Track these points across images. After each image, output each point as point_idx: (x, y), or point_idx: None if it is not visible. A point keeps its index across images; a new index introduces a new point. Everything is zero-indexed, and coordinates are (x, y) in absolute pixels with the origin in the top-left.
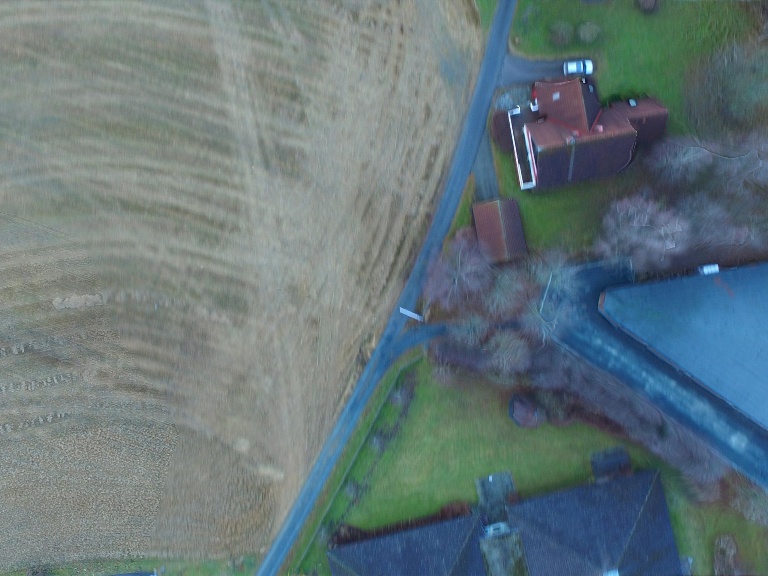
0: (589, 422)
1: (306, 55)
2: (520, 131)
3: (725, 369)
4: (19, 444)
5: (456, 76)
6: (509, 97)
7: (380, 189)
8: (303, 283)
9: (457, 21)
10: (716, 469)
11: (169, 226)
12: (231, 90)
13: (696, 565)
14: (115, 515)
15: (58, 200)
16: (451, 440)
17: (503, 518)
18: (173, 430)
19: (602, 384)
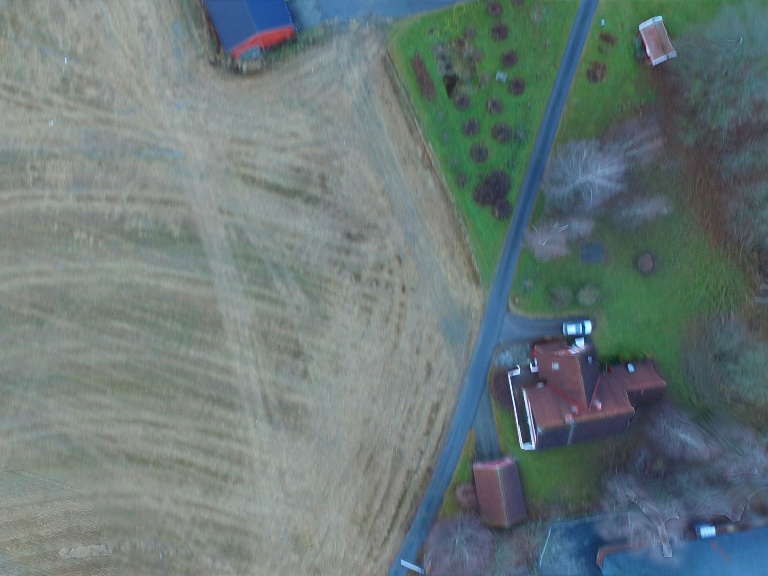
0: None
1: (309, 314)
2: (520, 391)
3: None
4: None
5: (457, 334)
6: (509, 354)
7: (382, 444)
8: (306, 533)
9: (458, 281)
10: None
11: (174, 478)
12: (235, 348)
13: None
14: None
15: (64, 454)
16: None
17: None
18: None
19: None
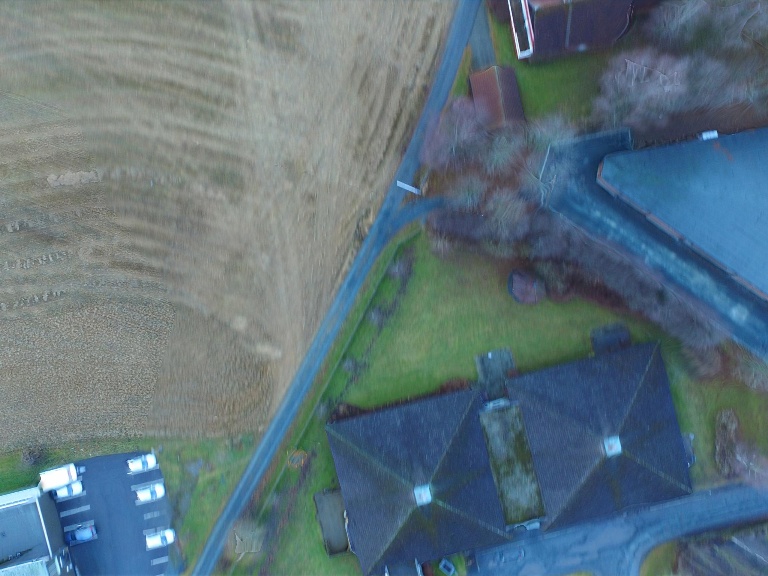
0: (589, 297)
1: None
2: (517, 0)
3: (725, 234)
4: (15, 323)
5: None
6: None
7: (376, 62)
8: (299, 158)
9: None
10: (717, 341)
11: (164, 101)
12: None
13: (697, 442)
14: (112, 394)
15: (52, 75)
16: (450, 317)
17: (503, 394)
18: (170, 308)
19: (601, 249)
